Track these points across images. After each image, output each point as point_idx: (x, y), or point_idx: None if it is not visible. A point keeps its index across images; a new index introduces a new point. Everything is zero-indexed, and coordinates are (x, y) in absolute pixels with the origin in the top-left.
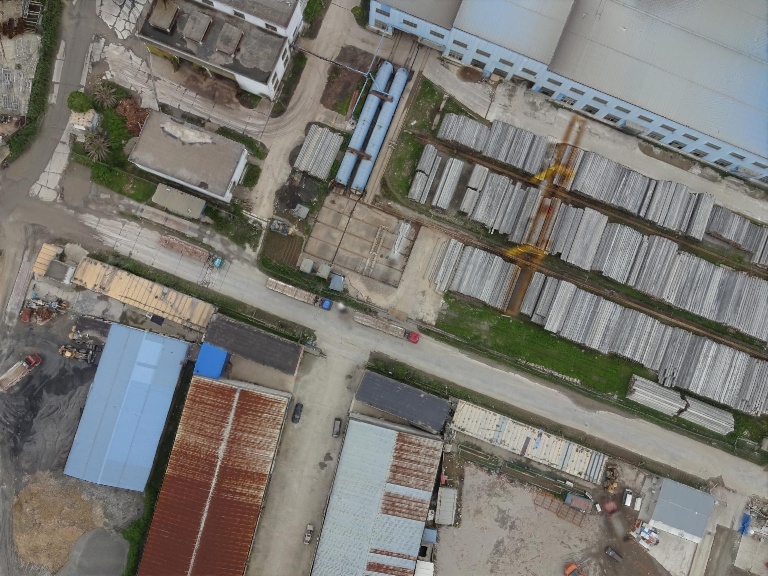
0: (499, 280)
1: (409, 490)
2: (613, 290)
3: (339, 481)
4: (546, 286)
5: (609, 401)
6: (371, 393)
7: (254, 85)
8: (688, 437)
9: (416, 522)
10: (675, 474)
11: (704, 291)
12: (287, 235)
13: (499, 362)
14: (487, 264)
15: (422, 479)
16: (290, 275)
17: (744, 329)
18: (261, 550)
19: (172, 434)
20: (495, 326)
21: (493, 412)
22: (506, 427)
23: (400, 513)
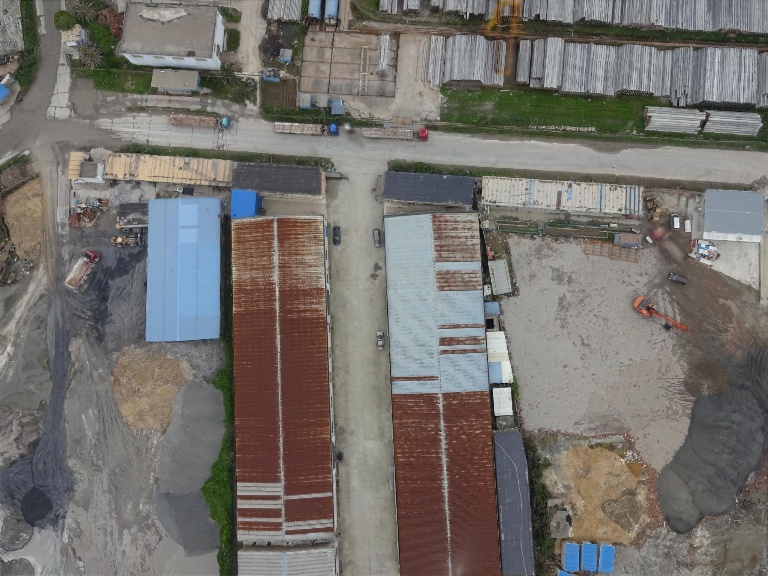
0: (488, 59)
1: (458, 264)
2: (601, 35)
3: (391, 275)
4: (534, 49)
5: (629, 137)
6: (397, 189)
7: None
8: (719, 149)
9: (474, 292)
10: (717, 187)
11: (692, 6)
12: (280, 81)
13: (511, 134)
14: (471, 45)
15: (467, 252)
16: (293, 115)
17: (744, 28)
18: (341, 367)
19: (231, 287)
20: (497, 103)
21: (518, 178)
22: (535, 188)
23: (456, 287)
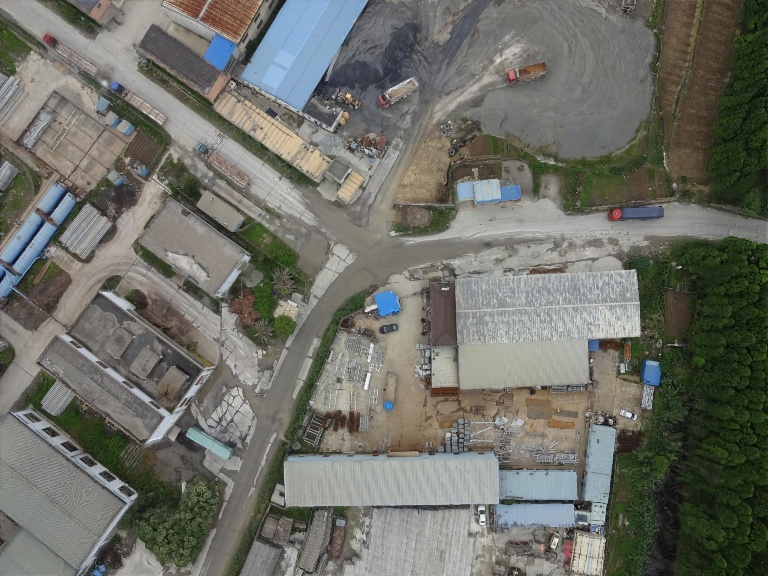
0: None
1: None
2: None
3: None
4: None
5: None
6: None
7: (116, 300)
8: None
9: None
10: None
11: None
12: None
13: None
14: None
15: None
16: (143, 123)
17: None
18: None
19: None
20: None
21: None
22: None
23: None
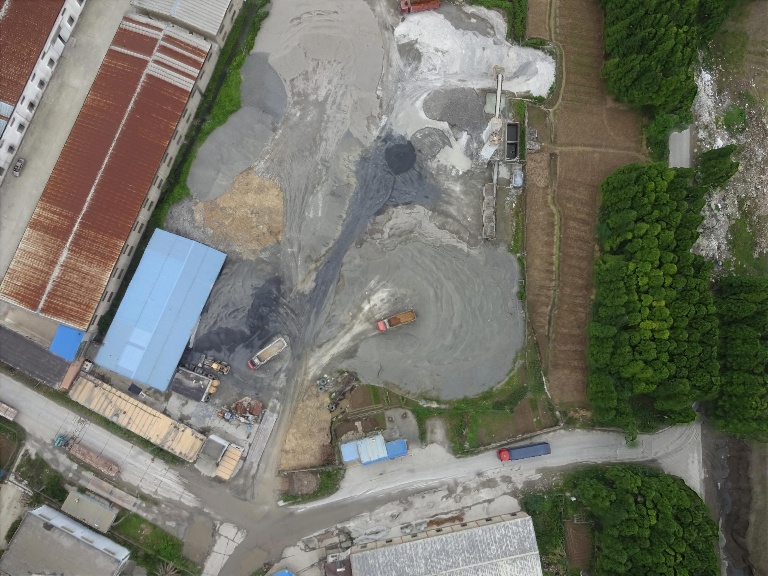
0: None
1: None
2: None
3: None
4: None
5: None
6: None
7: None
8: None
9: None
10: None
11: None
12: None
13: None
14: None
15: None
16: None
17: None
18: None
19: None
20: None
21: None
22: None
23: None
